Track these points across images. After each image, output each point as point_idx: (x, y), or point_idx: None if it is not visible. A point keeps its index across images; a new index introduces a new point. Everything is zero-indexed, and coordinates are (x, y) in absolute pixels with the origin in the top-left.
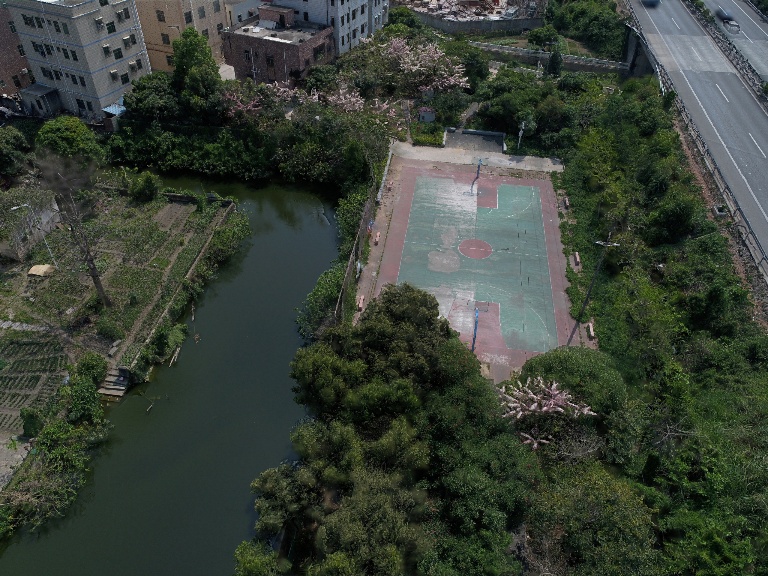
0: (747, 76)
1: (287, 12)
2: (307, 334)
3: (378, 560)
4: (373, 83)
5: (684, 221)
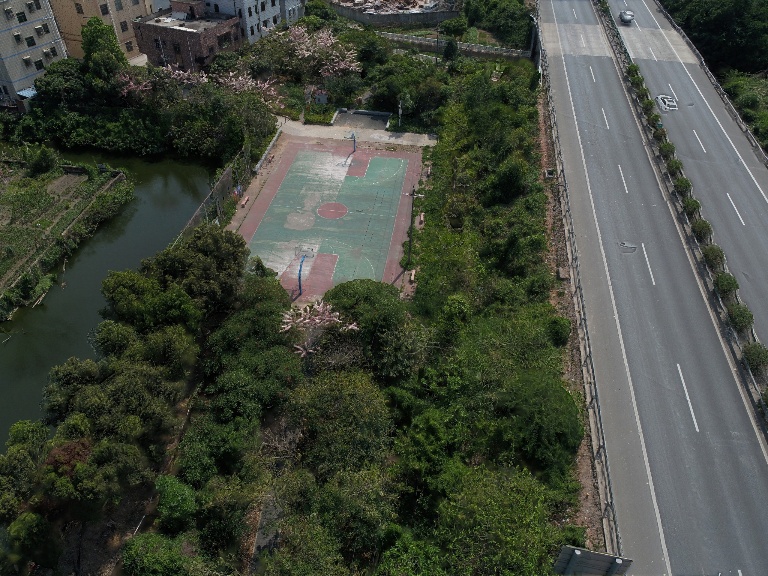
0: (620, 59)
1: (196, 4)
2: None
3: (114, 424)
4: (267, 67)
5: (514, 182)
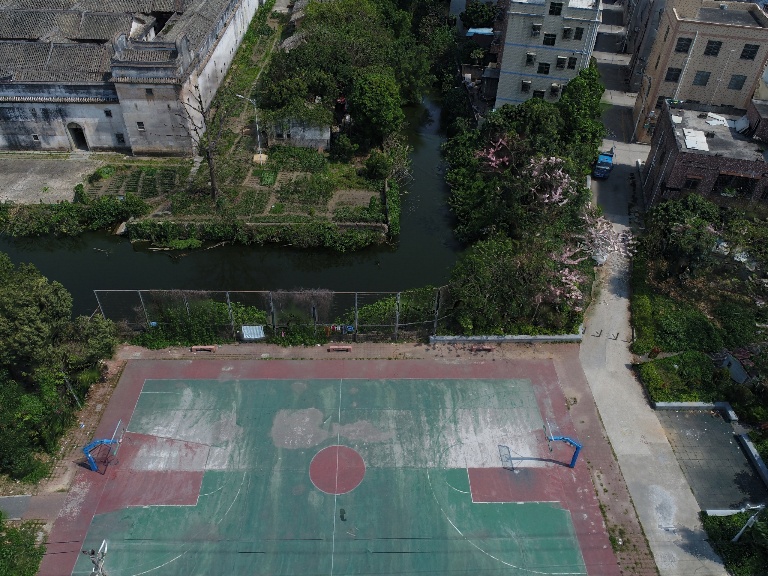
0: None
1: (767, 119)
2: None
3: None
4: (688, 253)
5: None
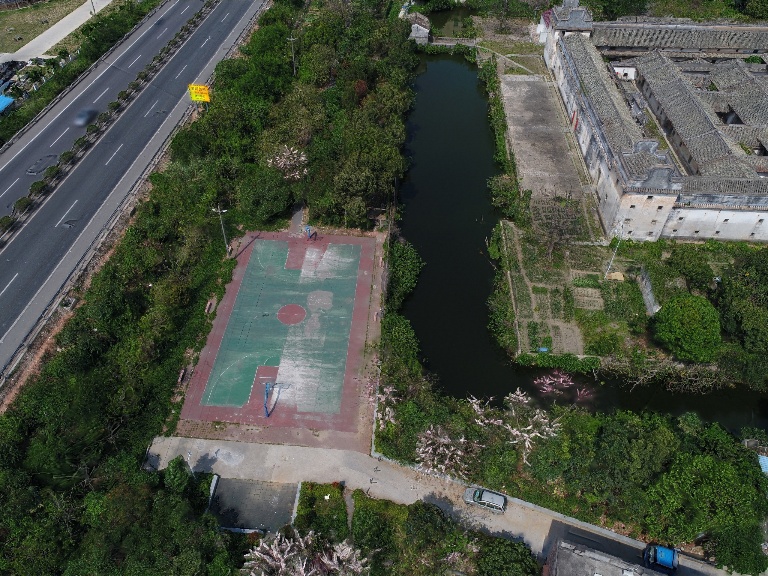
0: None
1: None
2: None
3: None
4: None
5: None
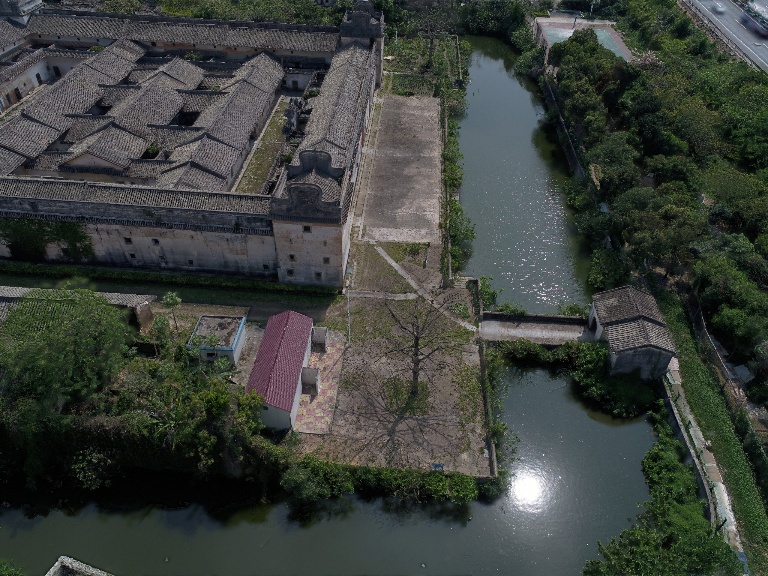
0: None
1: None
2: (525, 73)
3: None
4: None
5: (685, 28)
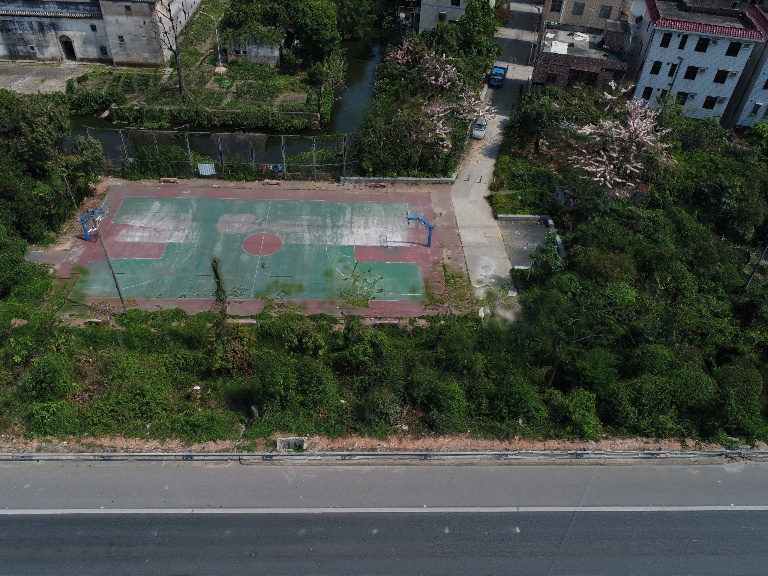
0: None
1: (612, 31)
2: None
3: None
4: (533, 117)
5: None
